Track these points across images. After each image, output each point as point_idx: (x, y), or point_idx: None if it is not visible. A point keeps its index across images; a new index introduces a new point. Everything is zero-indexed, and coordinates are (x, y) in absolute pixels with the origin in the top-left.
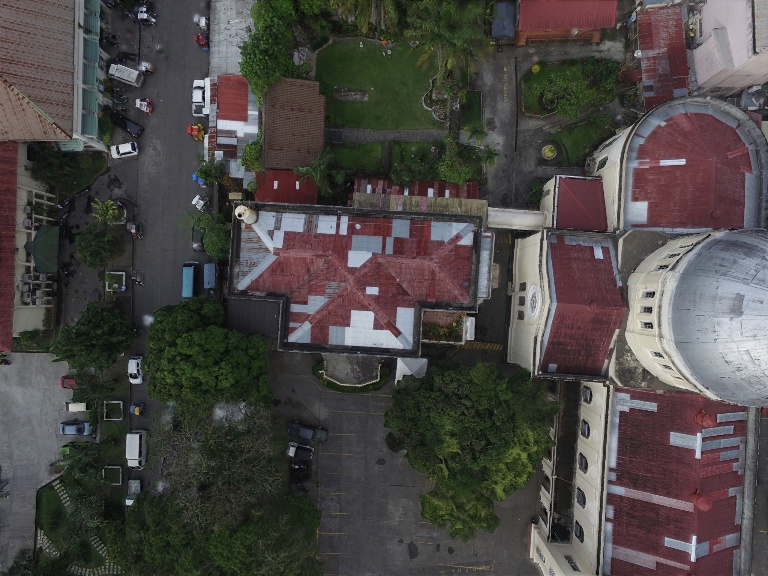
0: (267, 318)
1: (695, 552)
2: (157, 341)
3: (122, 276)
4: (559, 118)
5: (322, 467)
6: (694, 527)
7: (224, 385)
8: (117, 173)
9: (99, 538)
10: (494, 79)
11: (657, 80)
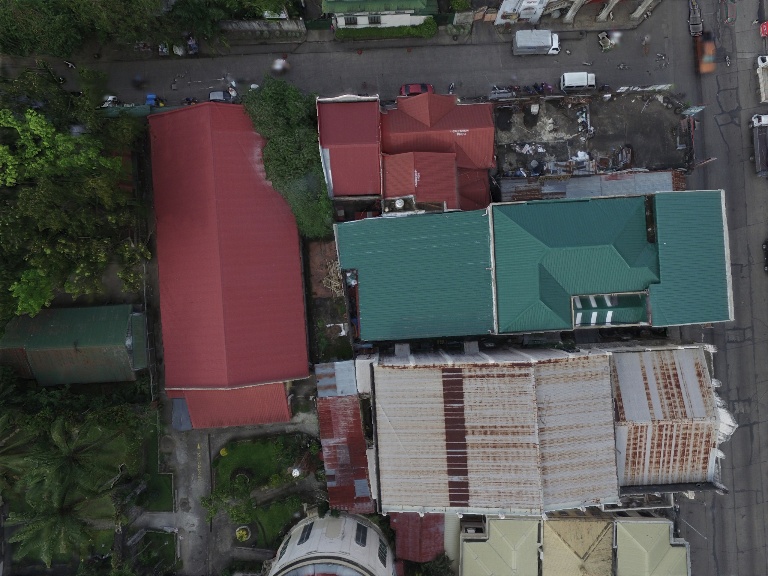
0: None
1: None
2: None
3: None
4: (254, 495)
5: None
6: None
7: None
8: None
9: None
10: (188, 457)
11: (338, 470)
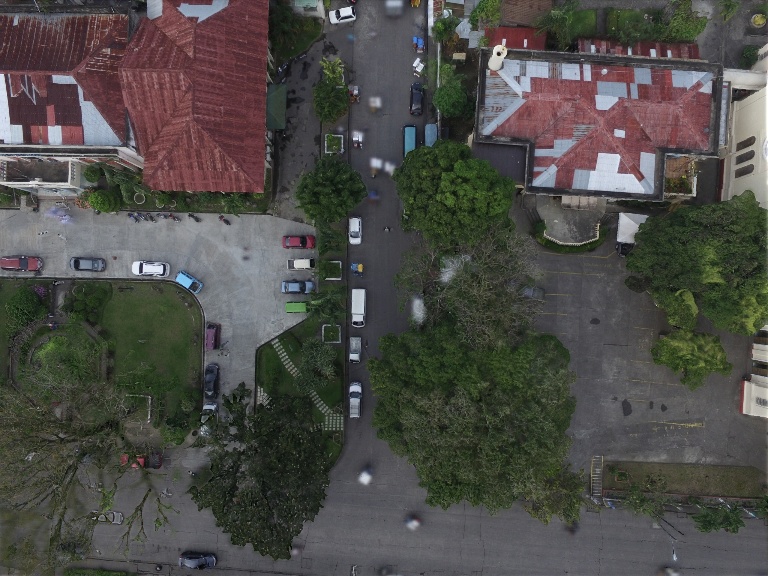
0: (509, 164)
1: None
2: (430, 169)
3: (340, 139)
4: None
5: (537, 327)
6: None
7: (496, 212)
8: (332, 40)
9: (318, 395)
10: None
11: None
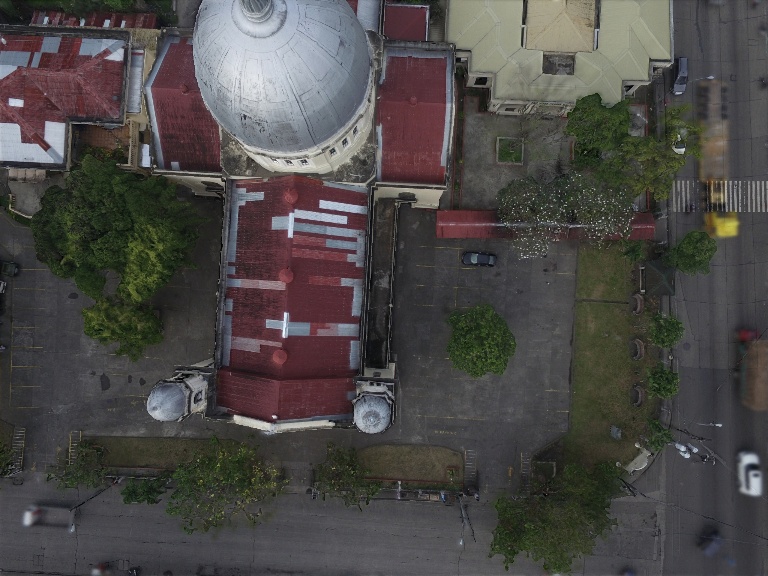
0: None
1: (285, 328)
2: None
3: None
4: None
5: (16, 302)
6: (285, 304)
7: None
8: None
9: None
10: None
11: None
